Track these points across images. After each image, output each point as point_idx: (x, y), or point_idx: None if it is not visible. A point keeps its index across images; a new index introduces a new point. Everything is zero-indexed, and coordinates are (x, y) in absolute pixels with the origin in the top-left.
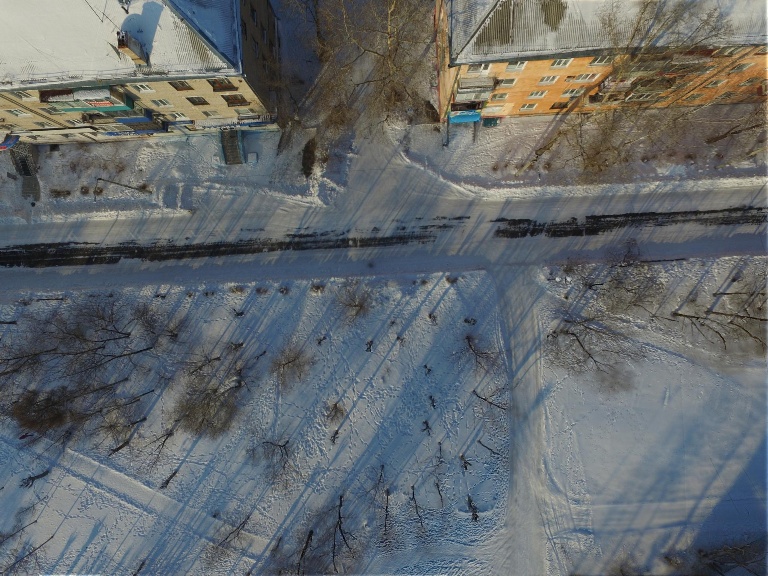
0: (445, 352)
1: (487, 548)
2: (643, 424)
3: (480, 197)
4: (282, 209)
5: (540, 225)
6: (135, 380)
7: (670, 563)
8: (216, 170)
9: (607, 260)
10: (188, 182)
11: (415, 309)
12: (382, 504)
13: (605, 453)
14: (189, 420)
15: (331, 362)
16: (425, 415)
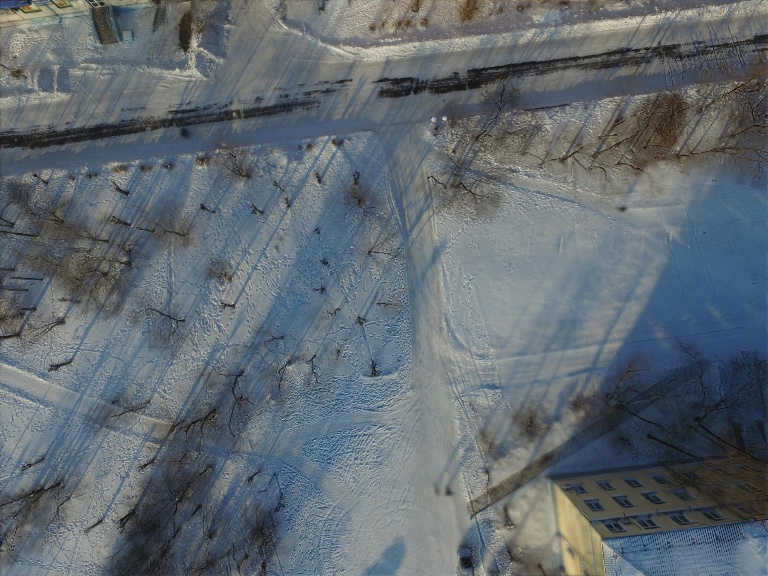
0: (337, 216)
1: (395, 413)
2: (540, 272)
3: (360, 58)
4: (162, 85)
5: (423, 82)
6: (22, 270)
7: (579, 410)
8: (92, 51)
9: (491, 111)
10: (64, 65)
11: (304, 176)
12: (285, 376)
13: (505, 305)
14: (80, 306)
15: (222, 235)
16: (322, 282)
